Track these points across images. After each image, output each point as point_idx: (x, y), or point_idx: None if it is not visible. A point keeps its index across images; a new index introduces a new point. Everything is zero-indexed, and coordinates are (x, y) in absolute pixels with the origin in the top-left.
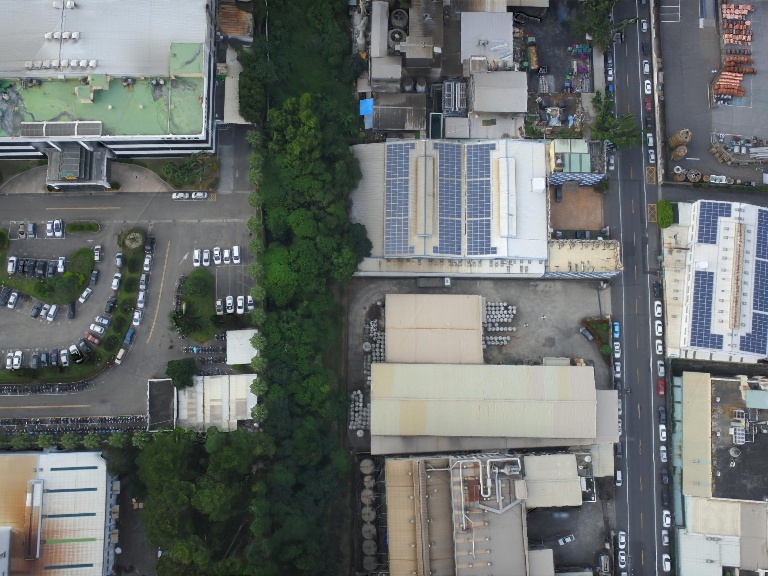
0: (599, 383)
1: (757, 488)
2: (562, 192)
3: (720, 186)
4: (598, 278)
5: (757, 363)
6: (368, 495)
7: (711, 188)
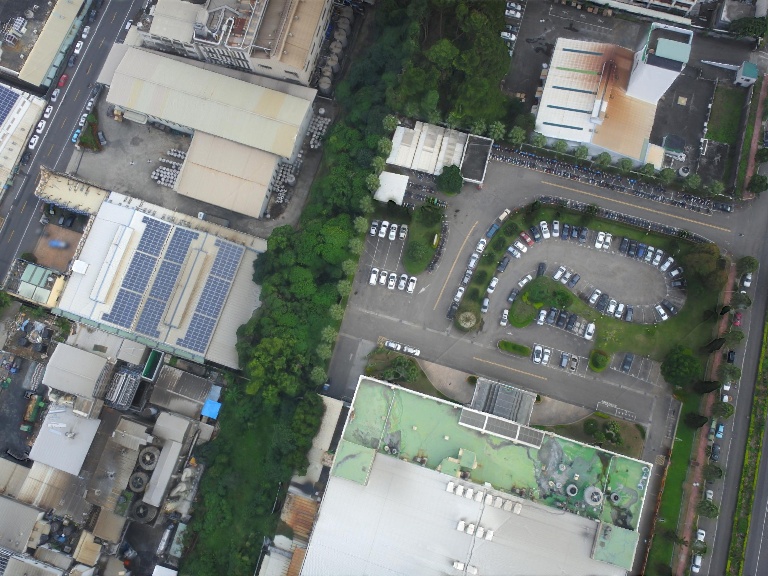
0: None
1: None
2: (66, 268)
3: None
4: None
5: None
6: (331, 60)
7: None
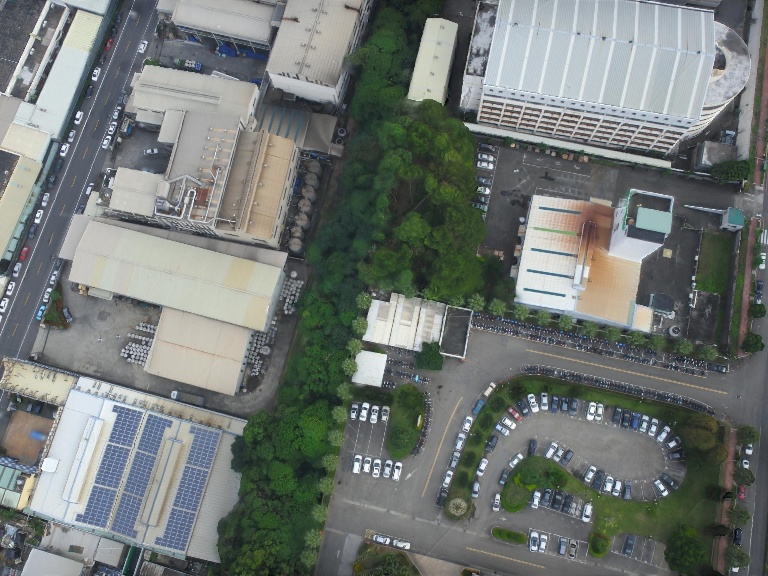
0: None
1: None
2: (37, 458)
3: None
4: None
5: None
6: (300, 220)
7: None
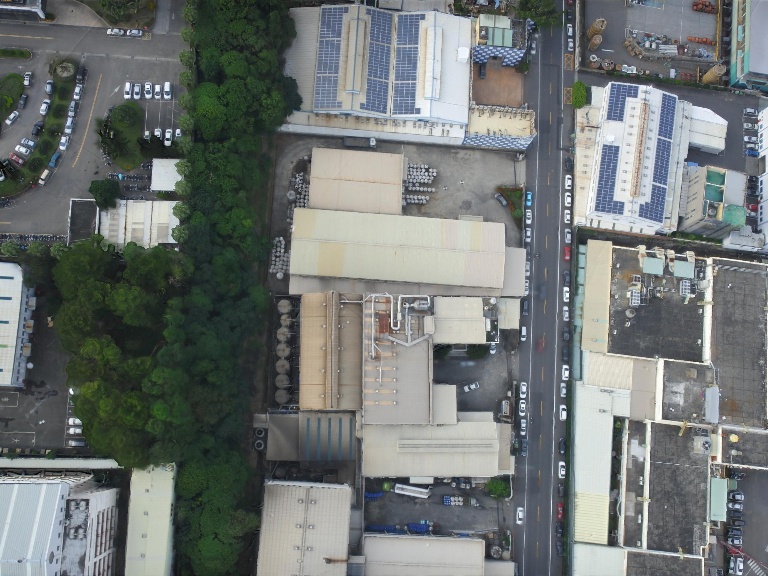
0: (510, 245)
1: (649, 347)
2: (486, 70)
3: (631, 76)
4: (515, 149)
5: (655, 235)
6: (284, 332)
7: (623, 77)
